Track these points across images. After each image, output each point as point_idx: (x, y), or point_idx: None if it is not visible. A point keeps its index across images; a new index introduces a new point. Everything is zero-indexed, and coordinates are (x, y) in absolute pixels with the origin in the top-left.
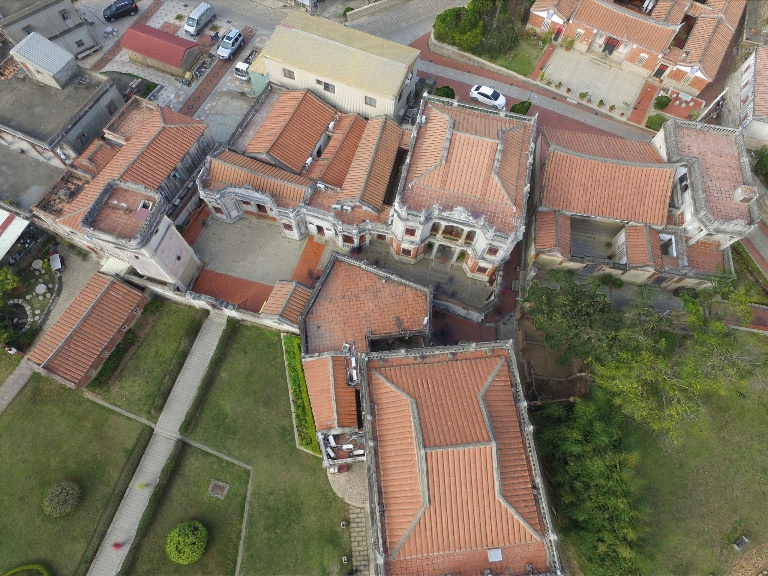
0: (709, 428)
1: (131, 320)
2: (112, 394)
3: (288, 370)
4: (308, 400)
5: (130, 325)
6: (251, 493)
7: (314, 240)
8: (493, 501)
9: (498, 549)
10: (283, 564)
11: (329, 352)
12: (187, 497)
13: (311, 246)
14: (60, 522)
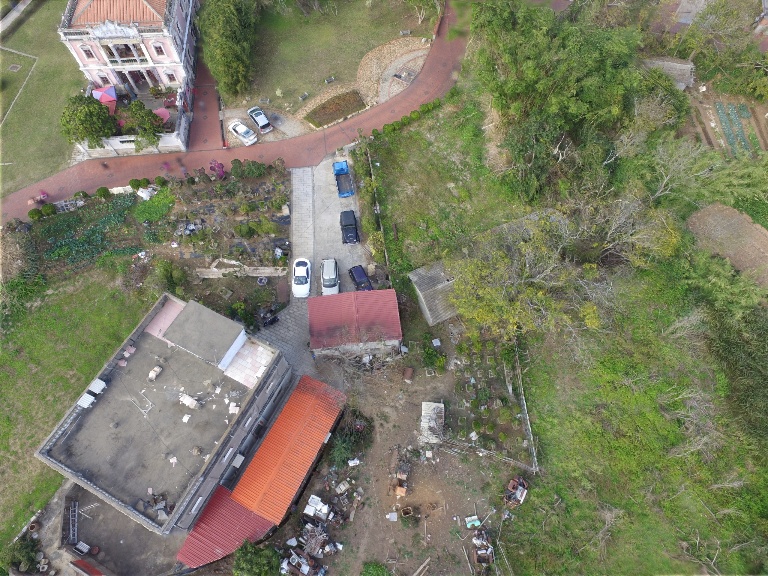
0: (333, 35)
1: None
2: None
3: None
4: None
5: None
6: (34, 68)
7: None
8: None
9: (137, 23)
10: (44, 93)
11: None
12: None
13: None
14: None
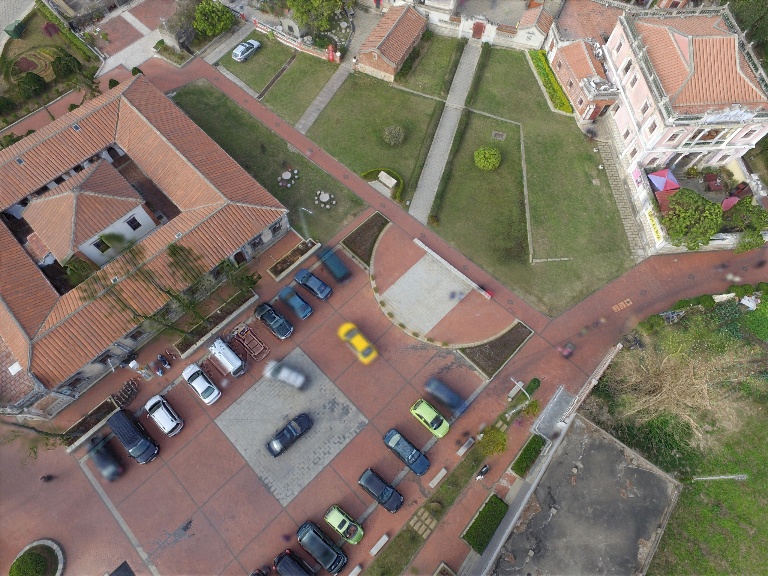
0: None
1: (417, 39)
2: (410, 84)
3: (537, 69)
4: (557, 82)
5: (415, 43)
6: (524, 136)
7: (535, 1)
8: (735, 73)
9: (739, 104)
10: (557, 170)
11: (580, 38)
12: (478, 139)
13: (533, 4)
14: (394, 150)
